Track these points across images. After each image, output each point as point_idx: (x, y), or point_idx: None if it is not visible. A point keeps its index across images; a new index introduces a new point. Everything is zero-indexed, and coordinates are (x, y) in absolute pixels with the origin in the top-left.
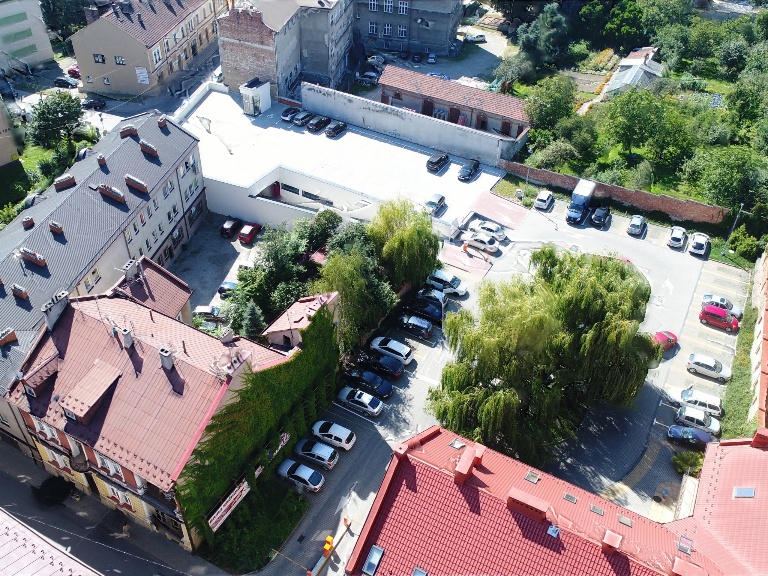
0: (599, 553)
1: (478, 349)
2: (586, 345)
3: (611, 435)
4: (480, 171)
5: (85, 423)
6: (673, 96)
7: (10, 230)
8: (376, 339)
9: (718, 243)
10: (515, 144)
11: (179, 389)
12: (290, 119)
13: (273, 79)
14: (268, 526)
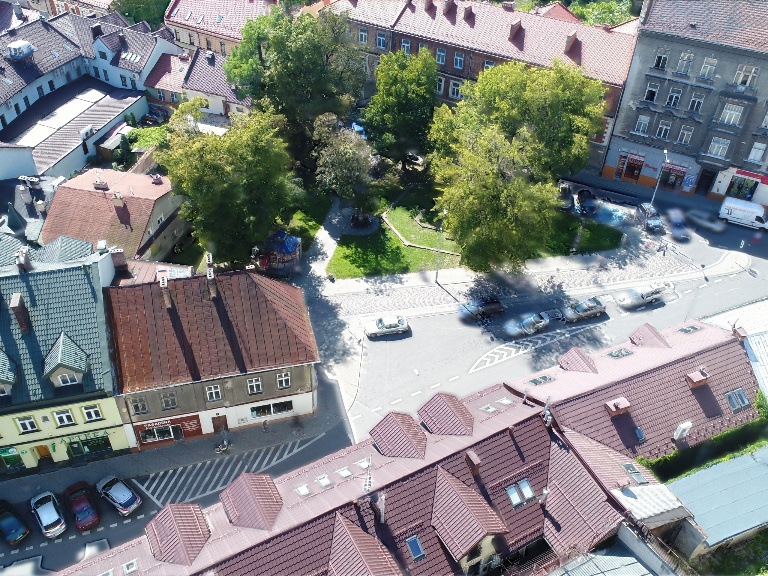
0: None
1: None
2: None
3: None
4: None
5: None
6: None
7: None
8: None
9: None
10: None
11: None
12: None
13: None
14: None
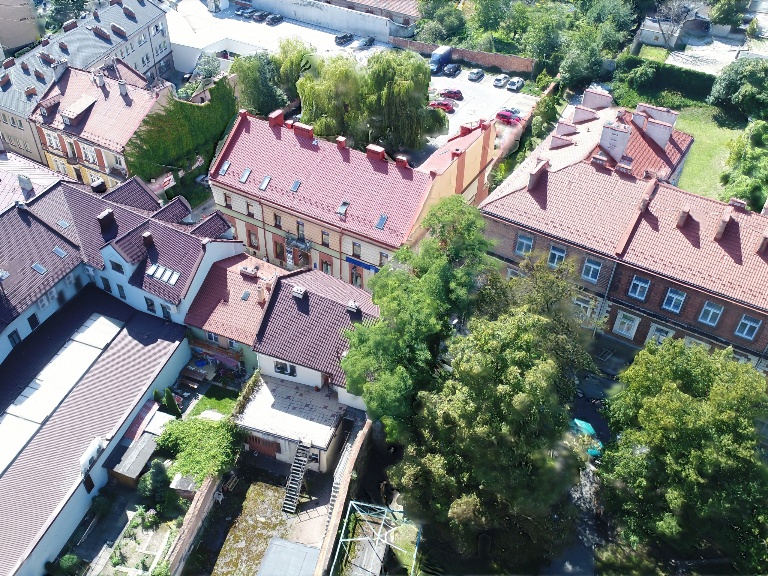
0: (336, 149)
1: (313, 96)
2: (383, 98)
3: None
4: None
5: (75, 125)
6: (544, 5)
7: (34, 50)
8: None
9: (529, 84)
10: (405, 29)
11: (129, 104)
12: (241, 13)
13: None
14: None
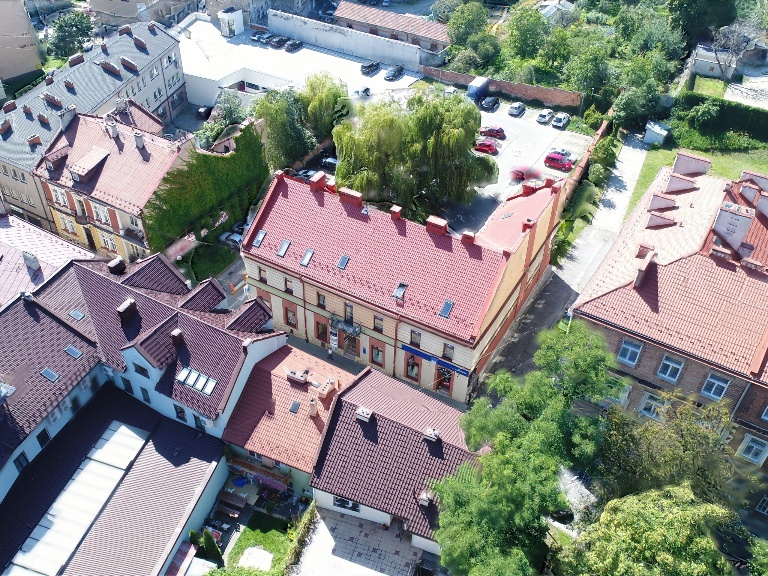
0: (390, 220)
1: (352, 146)
2: (430, 148)
3: (457, 224)
4: (403, 74)
5: (85, 182)
6: (579, 28)
7: (36, 89)
8: (300, 171)
9: (576, 120)
10: (435, 56)
11: (147, 159)
12: (258, 39)
13: (246, 8)
14: (209, 266)
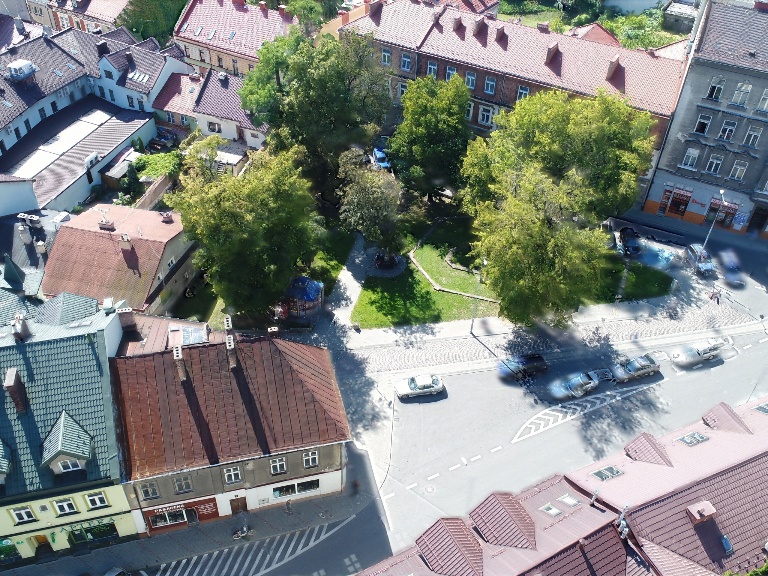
0: (259, 10)
1: None
2: None
3: None
4: None
5: (81, 7)
6: None
7: None
8: None
9: None
10: None
11: None
12: None
13: None
14: None
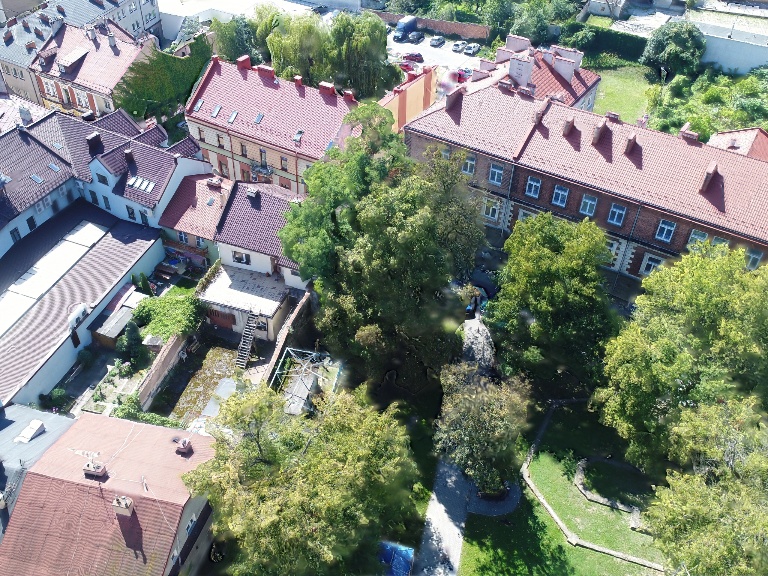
0: (294, 87)
1: (281, 49)
2: (343, 52)
3: None
4: None
5: (70, 73)
6: None
7: None
8: None
9: (485, 49)
10: (376, 2)
11: (117, 54)
12: None
13: None
14: None
